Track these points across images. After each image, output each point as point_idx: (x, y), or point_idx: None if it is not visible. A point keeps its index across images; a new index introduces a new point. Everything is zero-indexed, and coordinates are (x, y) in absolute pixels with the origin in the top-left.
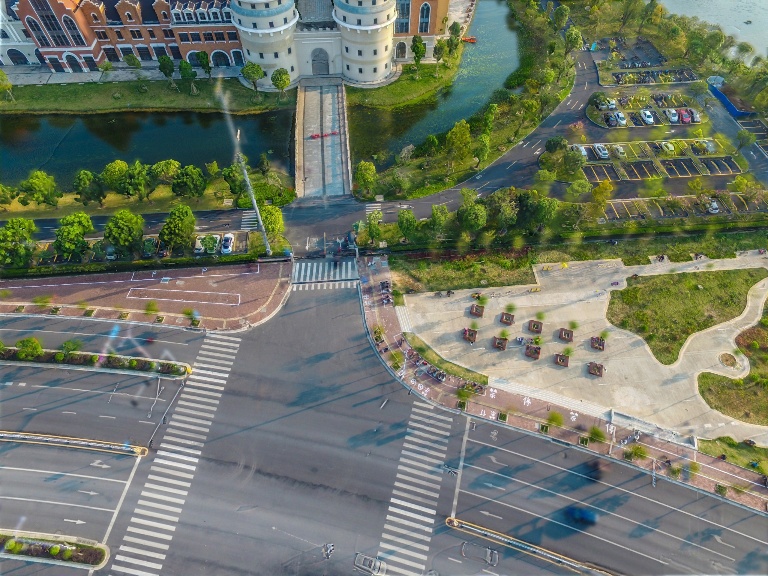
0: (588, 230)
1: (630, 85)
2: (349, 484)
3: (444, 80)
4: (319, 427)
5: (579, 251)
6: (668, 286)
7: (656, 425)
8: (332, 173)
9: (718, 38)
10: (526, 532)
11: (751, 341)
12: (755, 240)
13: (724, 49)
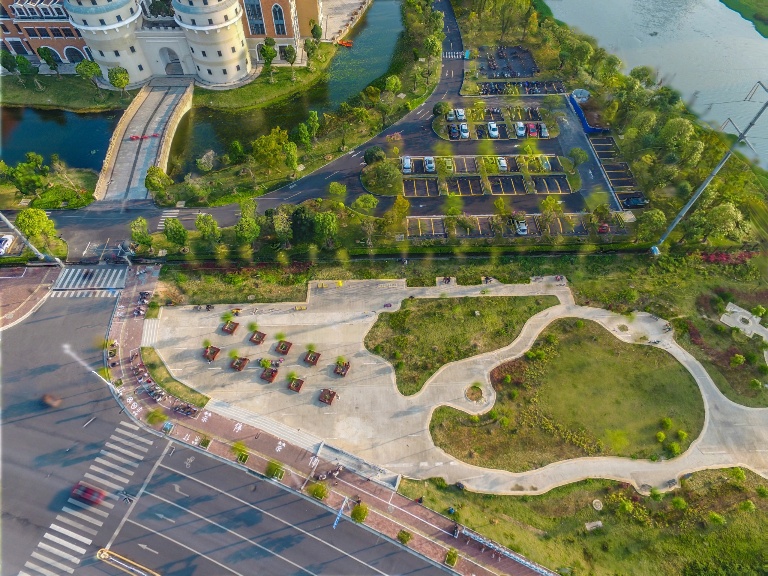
0: (381, 247)
1: (491, 96)
2: (15, 506)
3: (302, 84)
4: (11, 443)
5: (364, 269)
6: (444, 310)
7: (364, 461)
8: (140, 176)
9: (584, 50)
10: (177, 570)
11: (508, 374)
12: (557, 265)
13: (597, 61)
